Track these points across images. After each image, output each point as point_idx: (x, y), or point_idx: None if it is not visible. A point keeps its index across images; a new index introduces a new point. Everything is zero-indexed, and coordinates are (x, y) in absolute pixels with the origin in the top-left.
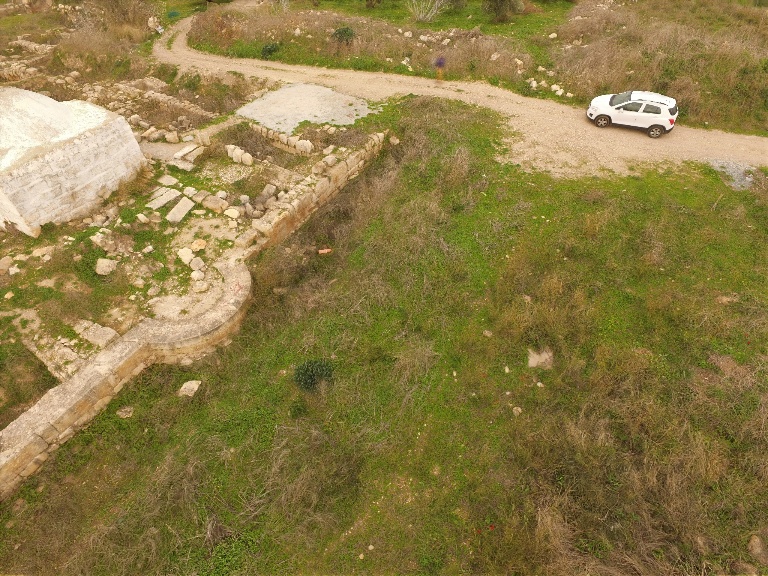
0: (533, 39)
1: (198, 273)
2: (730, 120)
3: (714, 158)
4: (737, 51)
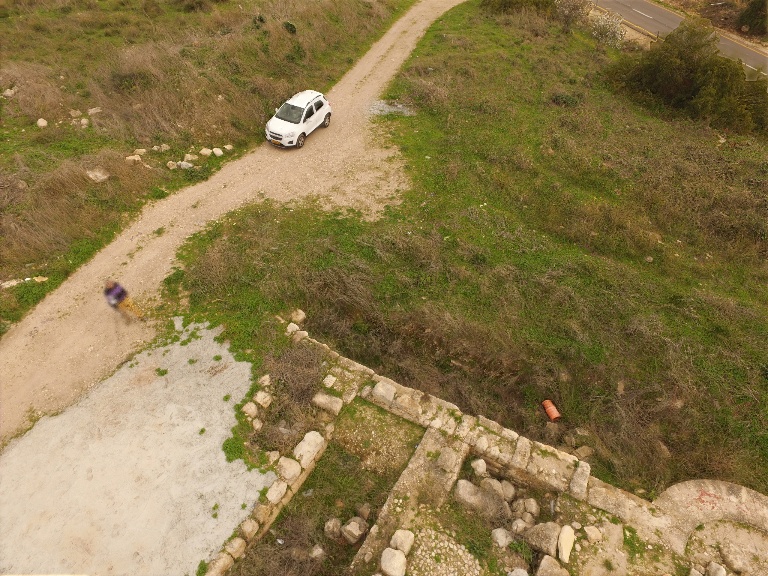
0: (41, 138)
1: (722, 569)
2: (310, 87)
3: (366, 110)
4: (240, 40)
